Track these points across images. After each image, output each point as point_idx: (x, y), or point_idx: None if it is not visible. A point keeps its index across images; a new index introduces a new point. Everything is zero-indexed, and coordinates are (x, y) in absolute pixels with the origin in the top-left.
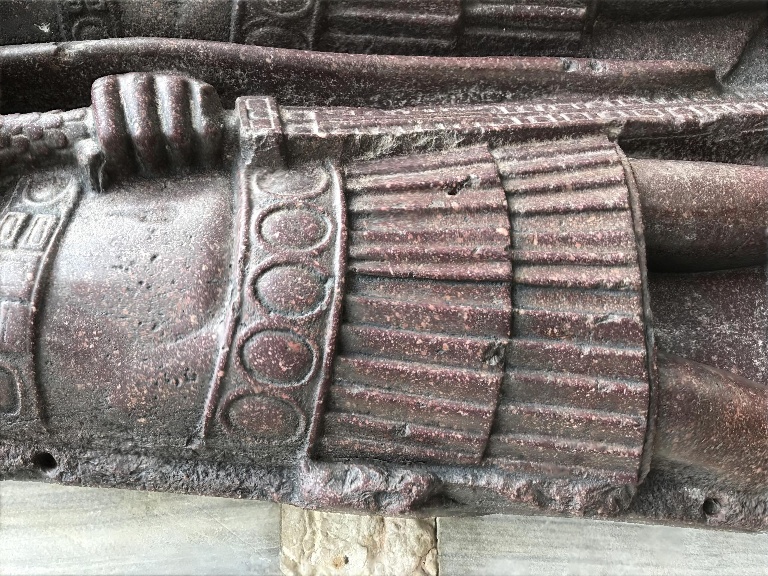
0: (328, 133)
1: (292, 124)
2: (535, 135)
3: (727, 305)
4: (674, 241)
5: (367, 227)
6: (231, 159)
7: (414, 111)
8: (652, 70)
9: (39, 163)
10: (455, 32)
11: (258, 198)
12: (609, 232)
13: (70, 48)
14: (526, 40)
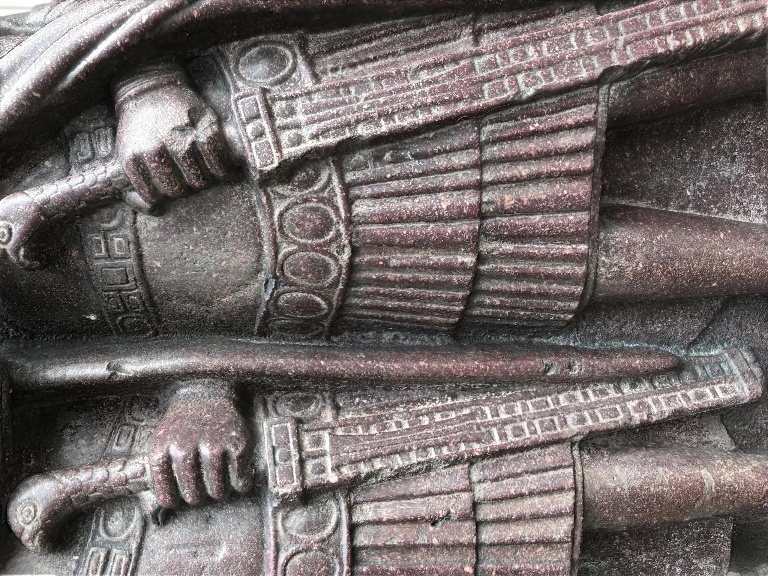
0: (339, 475)
1: (310, 459)
2: (509, 452)
3: (648, 540)
4: (608, 531)
5: (366, 557)
6: (260, 486)
7: (412, 421)
8: (622, 371)
9: (109, 499)
10: (455, 325)
11: (283, 540)
12: (551, 567)
13: (120, 368)
14: (518, 325)
